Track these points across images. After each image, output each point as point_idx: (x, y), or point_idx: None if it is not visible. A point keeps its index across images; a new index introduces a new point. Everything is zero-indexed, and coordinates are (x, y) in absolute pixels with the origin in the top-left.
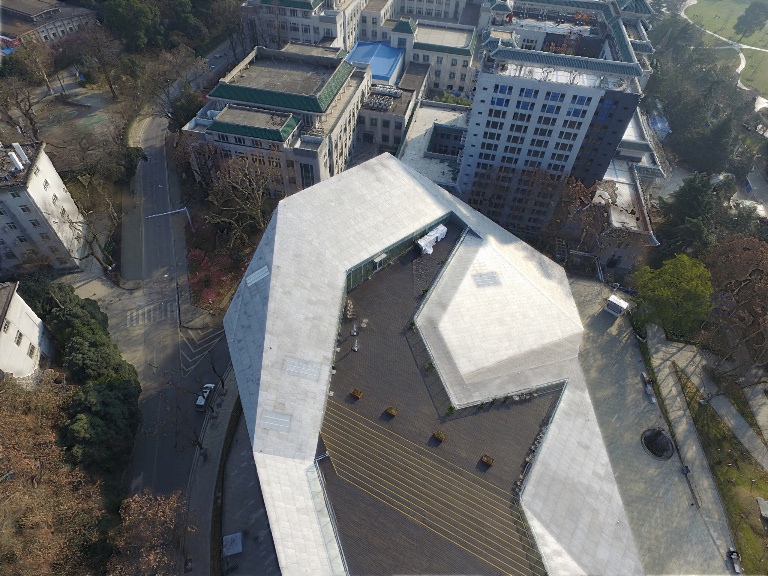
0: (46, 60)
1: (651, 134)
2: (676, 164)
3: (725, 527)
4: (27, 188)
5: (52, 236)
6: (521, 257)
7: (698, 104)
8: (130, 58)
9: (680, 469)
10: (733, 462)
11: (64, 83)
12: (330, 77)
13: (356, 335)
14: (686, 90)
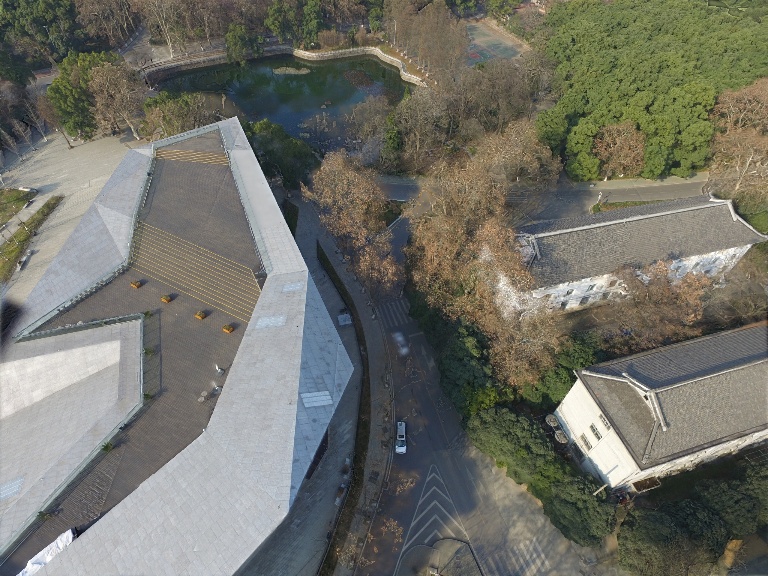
0: None
1: None
2: None
3: None
4: None
5: None
6: None
7: None
8: None
9: None
10: None
11: None
12: None
13: None
14: None
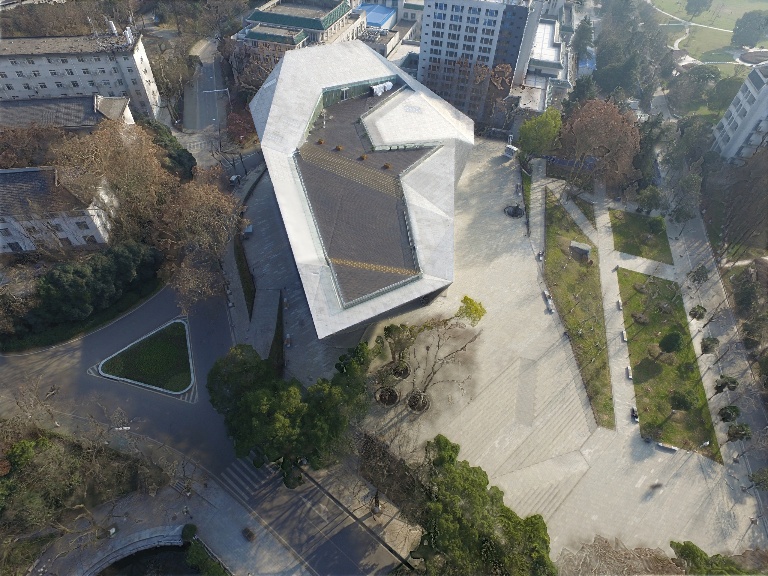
0: (134, 3)
1: (572, 63)
2: (598, 93)
3: (542, 245)
4: (134, 53)
5: (143, 93)
6: (441, 106)
7: (615, 46)
8: (192, 6)
9: (524, 222)
10: (565, 229)
11: (144, 23)
12: (332, 10)
13: (325, 123)
14: (612, 40)
